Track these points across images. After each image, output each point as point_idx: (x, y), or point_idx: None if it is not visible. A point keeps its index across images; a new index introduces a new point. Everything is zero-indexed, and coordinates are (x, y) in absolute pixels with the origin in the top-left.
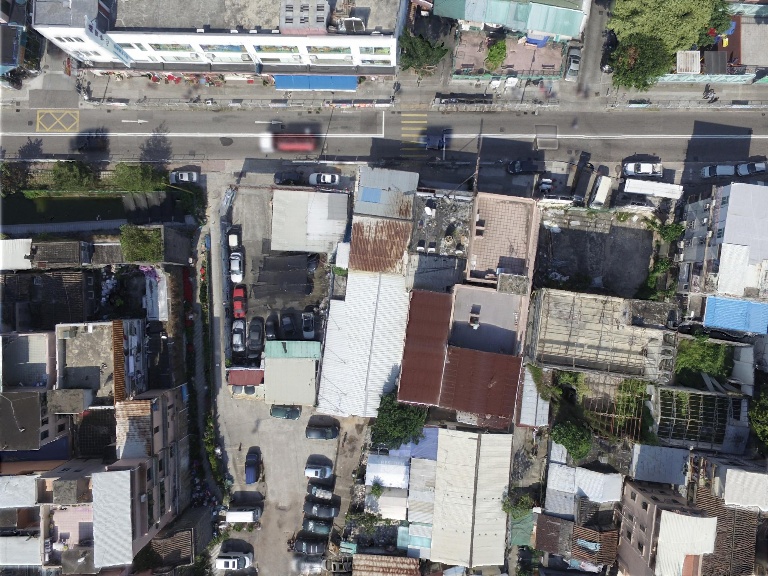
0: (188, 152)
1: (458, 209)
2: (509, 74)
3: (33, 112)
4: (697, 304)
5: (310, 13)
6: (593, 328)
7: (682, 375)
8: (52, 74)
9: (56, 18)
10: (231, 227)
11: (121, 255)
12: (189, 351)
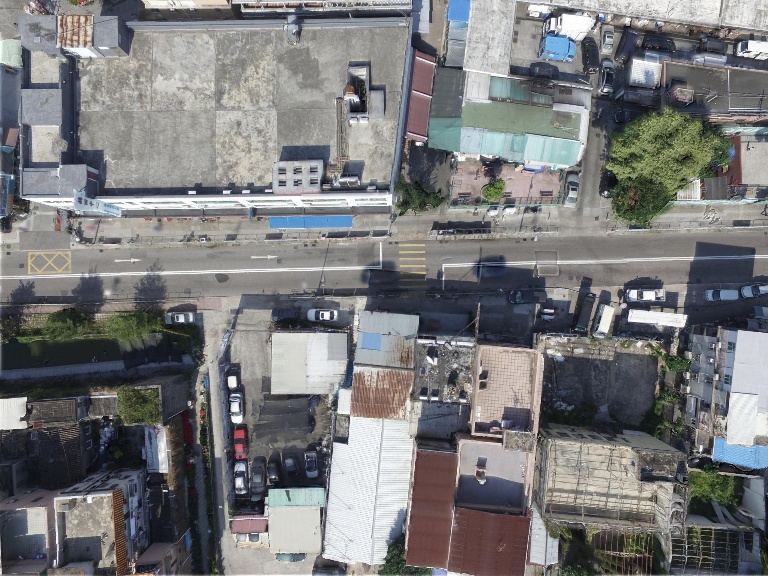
0: (183, 290)
1: (460, 355)
2: (507, 202)
3: (24, 254)
4: (705, 435)
5: (303, 175)
6: (601, 476)
7: (692, 506)
8: (42, 215)
9: (44, 188)
10: (230, 366)
11: None
12: (191, 495)
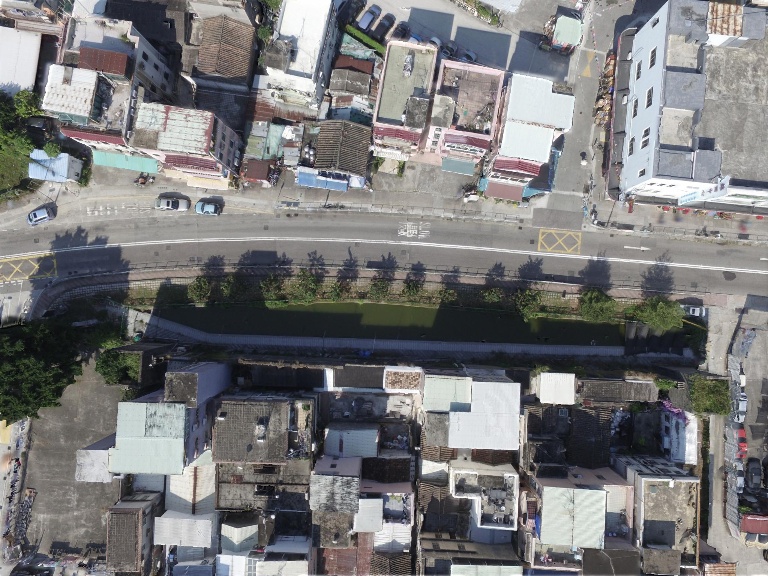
0: (690, 284)
1: None
2: None
3: (536, 231)
4: None
5: None
6: None
7: None
8: (558, 194)
9: (677, 170)
10: None
11: (649, 393)
12: None
